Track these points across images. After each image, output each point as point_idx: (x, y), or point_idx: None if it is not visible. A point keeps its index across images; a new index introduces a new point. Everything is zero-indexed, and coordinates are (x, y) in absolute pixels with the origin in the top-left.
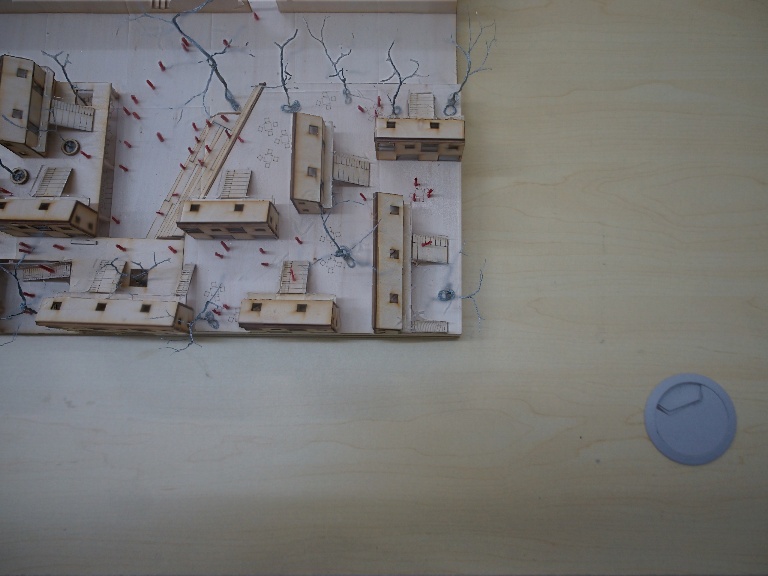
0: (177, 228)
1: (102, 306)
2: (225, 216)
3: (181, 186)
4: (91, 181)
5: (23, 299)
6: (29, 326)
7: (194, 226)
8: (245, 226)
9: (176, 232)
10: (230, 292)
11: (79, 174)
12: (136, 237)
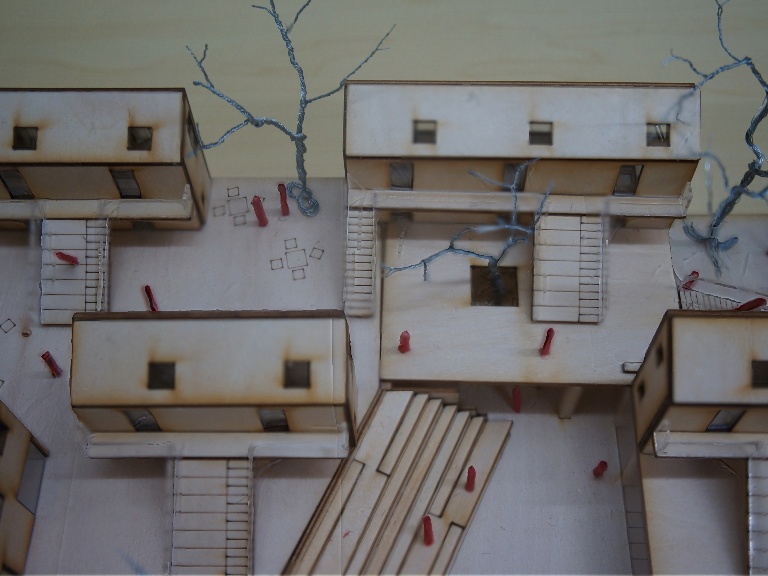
0: (403, 412)
1: (540, 138)
2: (200, 342)
3: (417, 568)
4: (681, 548)
5: (760, 172)
6: (767, 228)
7: (293, 312)
8: (141, 313)
9: (404, 400)
10: (258, 258)
11: (725, 571)
12: (541, 434)
